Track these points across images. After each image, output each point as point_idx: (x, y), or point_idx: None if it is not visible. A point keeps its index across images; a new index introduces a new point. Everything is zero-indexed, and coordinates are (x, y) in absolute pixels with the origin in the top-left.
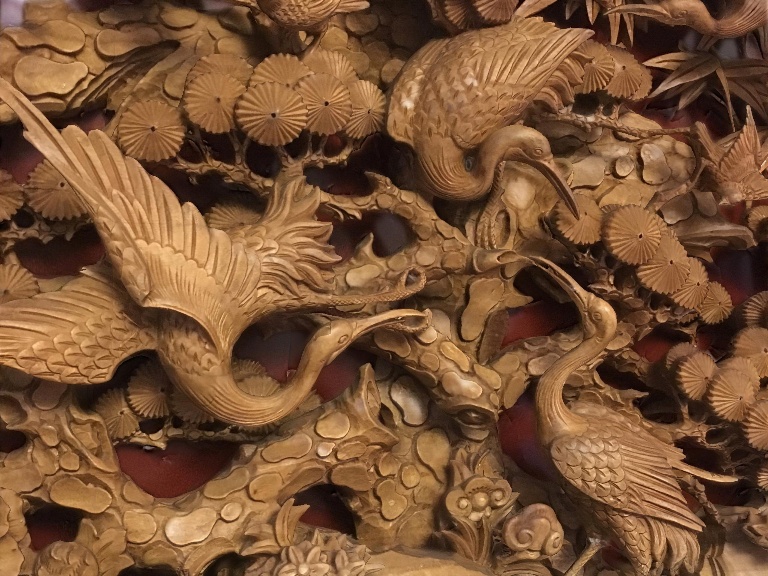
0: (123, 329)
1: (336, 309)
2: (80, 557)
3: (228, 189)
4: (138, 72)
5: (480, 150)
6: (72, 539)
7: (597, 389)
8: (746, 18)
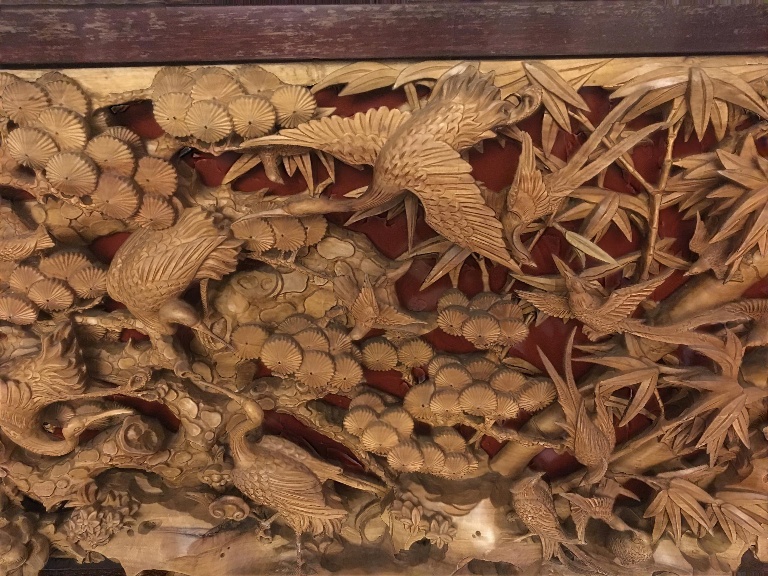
0: None
1: None
2: None
3: None
4: None
5: None
6: None
7: None
8: (375, 198)
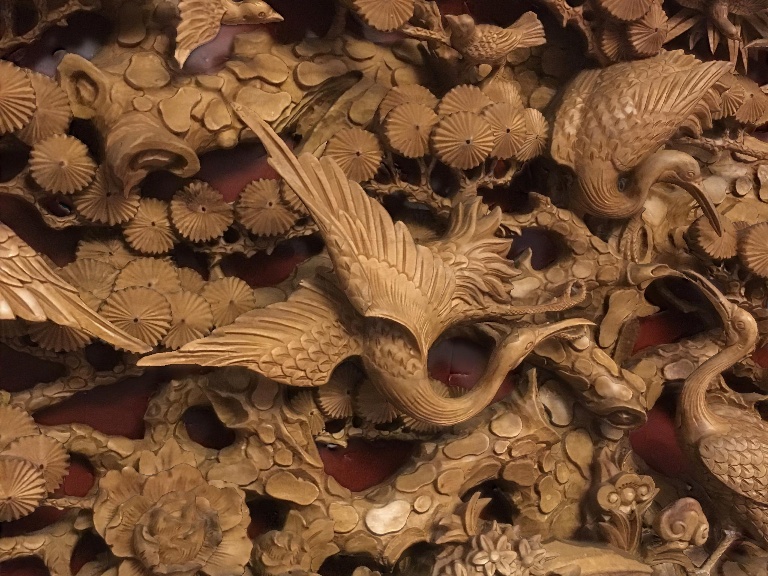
0: (338, 336)
1: (504, 318)
2: (298, 544)
3: (408, 208)
4: (324, 100)
5: (636, 173)
6: (280, 529)
7: (722, 393)
8: None
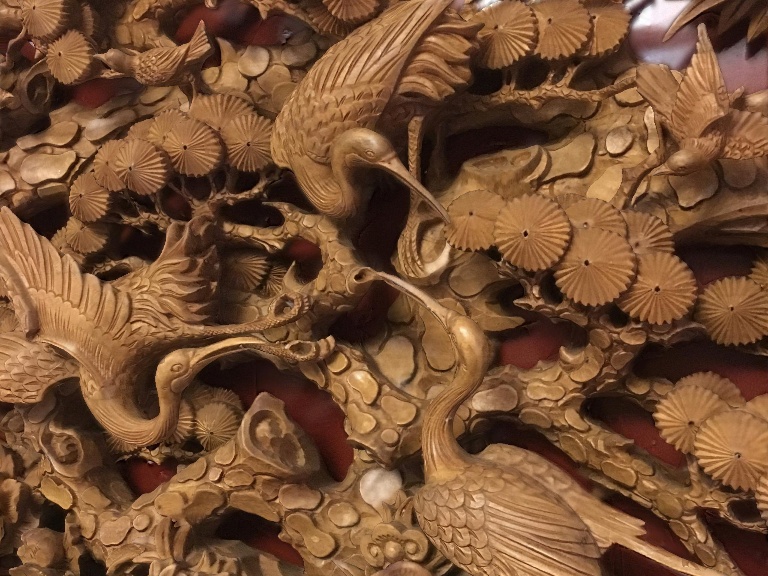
0: (49, 360)
1: None
2: None
3: None
4: None
5: None
6: None
7: (577, 432)
8: None
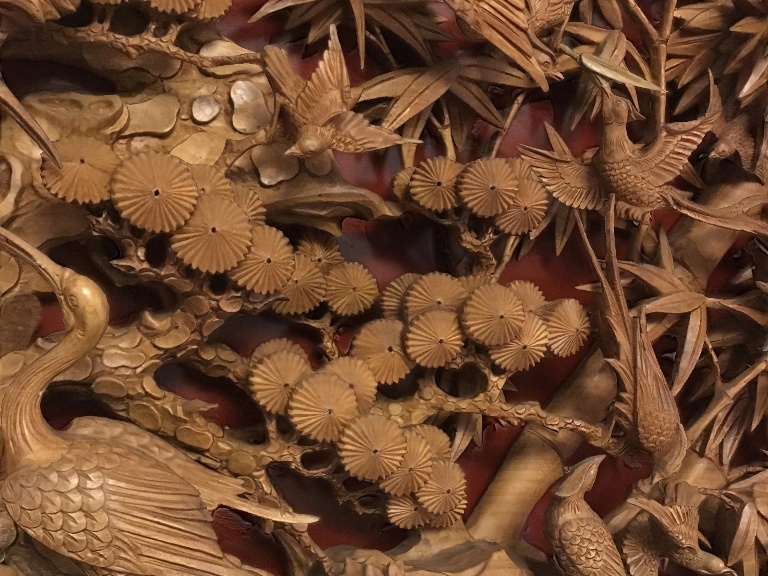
0: None
1: None
2: None
3: None
4: None
5: None
6: None
7: (152, 400)
8: None
